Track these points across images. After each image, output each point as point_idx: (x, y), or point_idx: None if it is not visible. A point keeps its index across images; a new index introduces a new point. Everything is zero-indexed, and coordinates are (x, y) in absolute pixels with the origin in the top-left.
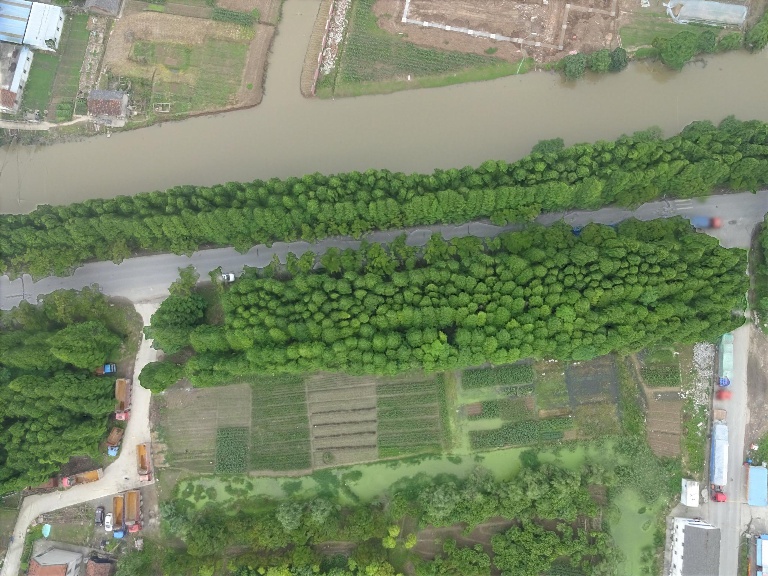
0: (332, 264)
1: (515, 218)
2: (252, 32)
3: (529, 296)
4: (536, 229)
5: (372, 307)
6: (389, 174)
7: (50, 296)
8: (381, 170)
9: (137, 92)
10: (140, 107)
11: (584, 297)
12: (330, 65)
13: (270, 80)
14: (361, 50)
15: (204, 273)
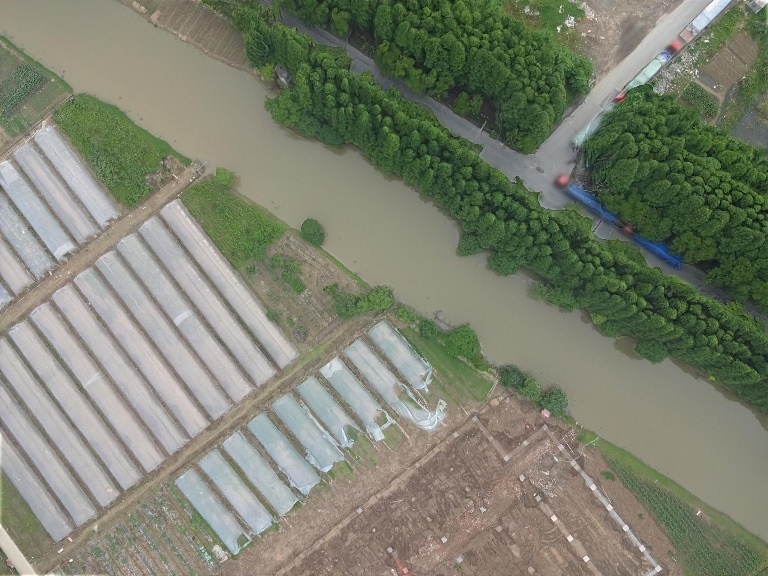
0: None
1: None
2: None
3: None
4: None
5: None
6: None
7: None
8: None
9: None
10: None
11: None
12: None
13: None
14: (724, 575)
15: None
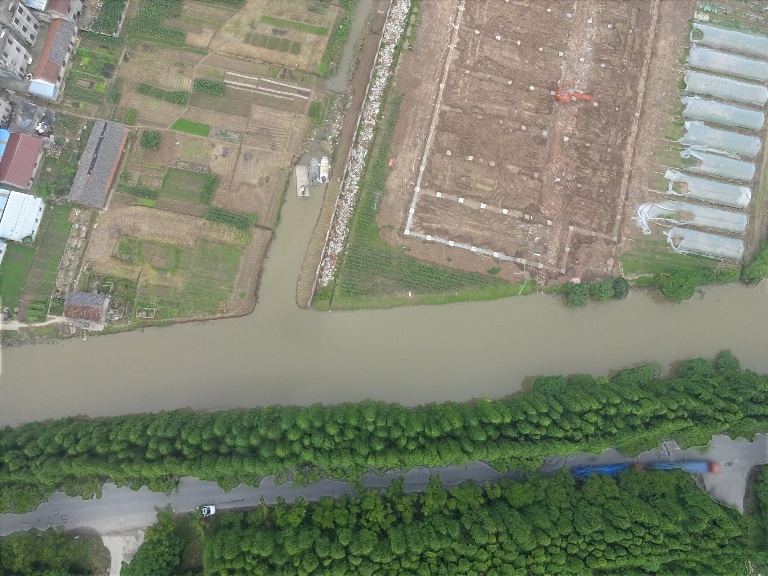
0: (325, 520)
1: (516, 466)
2: (248, 236)
3: (531, 563)
4: (538, 483)
5: (367, 575)
6: (389, 420)
7: (8, 540)
8: (380, 408)
9: (120, 294)
10: (122, 311)
11: (587, 566)
12: (328, 276)
13: (264, 287)
14: (362, 263)
15: (182, 503)
